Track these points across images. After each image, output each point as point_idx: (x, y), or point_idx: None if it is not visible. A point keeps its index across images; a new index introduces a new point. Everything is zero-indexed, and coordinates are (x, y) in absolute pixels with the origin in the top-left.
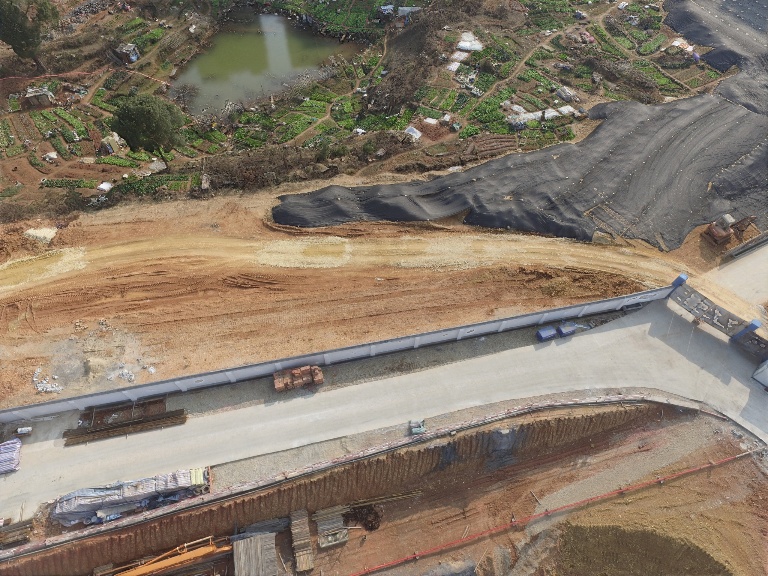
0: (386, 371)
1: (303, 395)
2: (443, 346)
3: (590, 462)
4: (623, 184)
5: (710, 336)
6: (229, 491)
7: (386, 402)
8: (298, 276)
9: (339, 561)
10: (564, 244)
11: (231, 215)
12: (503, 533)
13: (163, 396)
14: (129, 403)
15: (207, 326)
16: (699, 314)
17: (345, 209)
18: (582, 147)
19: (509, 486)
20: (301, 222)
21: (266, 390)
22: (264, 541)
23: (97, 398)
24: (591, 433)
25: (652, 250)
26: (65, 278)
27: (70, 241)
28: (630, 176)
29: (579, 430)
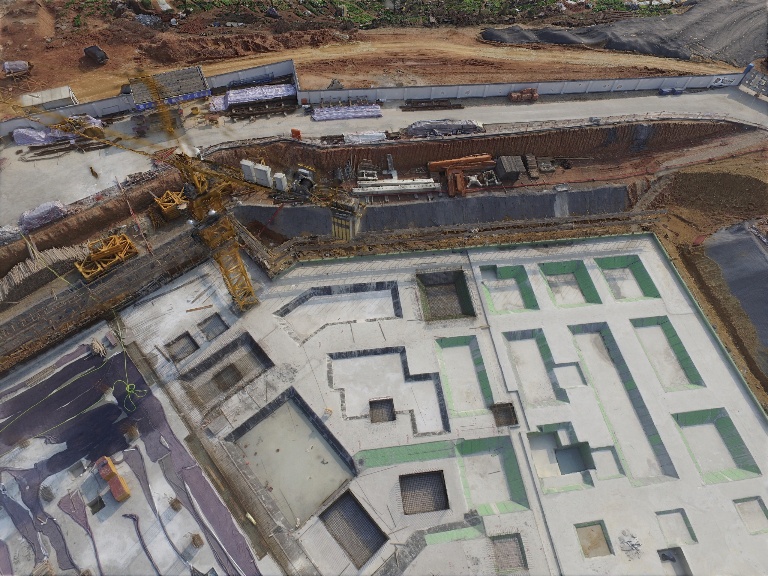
0: (571, 99)
1: (526, 104)
2: (603, 93)
3: (691, 150)
4: (709, 35)
5: (765, 102)
6: (498, 131)
7: (574, 110)
8: (506, 63)
9: (552, 177)
10: (671, 61)
11: (454, 35)
12: (642, 175)
13: (447, 99)
14: (429, 100)
15: (461, 76)
16: (759, 89)
17: (528, 35)
18: (681, 16)
19: (644, 158)
20: (501, 40)
21: (505, 101)
22: (516, 158)
23: (417, 91)
24: (692, 136)
25: (729, 66)
26: (366, 53)
27: (360, 39)
28: (714, 32)
29: (686, 132)
